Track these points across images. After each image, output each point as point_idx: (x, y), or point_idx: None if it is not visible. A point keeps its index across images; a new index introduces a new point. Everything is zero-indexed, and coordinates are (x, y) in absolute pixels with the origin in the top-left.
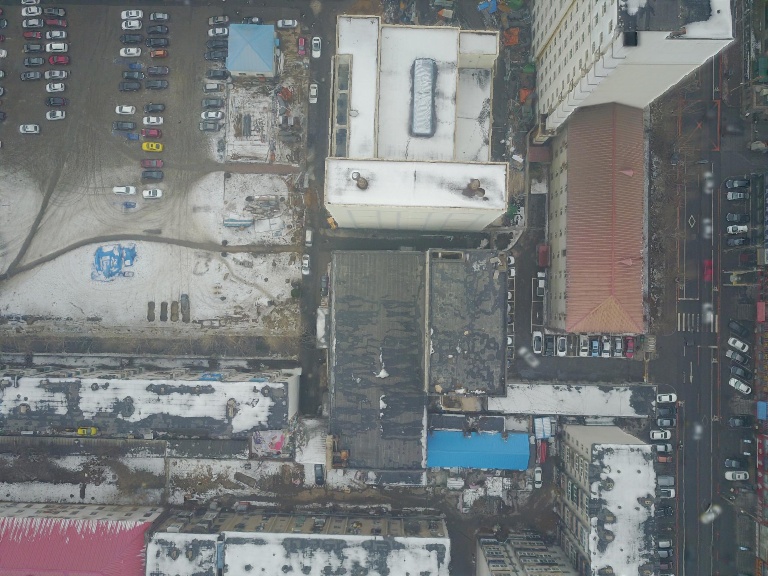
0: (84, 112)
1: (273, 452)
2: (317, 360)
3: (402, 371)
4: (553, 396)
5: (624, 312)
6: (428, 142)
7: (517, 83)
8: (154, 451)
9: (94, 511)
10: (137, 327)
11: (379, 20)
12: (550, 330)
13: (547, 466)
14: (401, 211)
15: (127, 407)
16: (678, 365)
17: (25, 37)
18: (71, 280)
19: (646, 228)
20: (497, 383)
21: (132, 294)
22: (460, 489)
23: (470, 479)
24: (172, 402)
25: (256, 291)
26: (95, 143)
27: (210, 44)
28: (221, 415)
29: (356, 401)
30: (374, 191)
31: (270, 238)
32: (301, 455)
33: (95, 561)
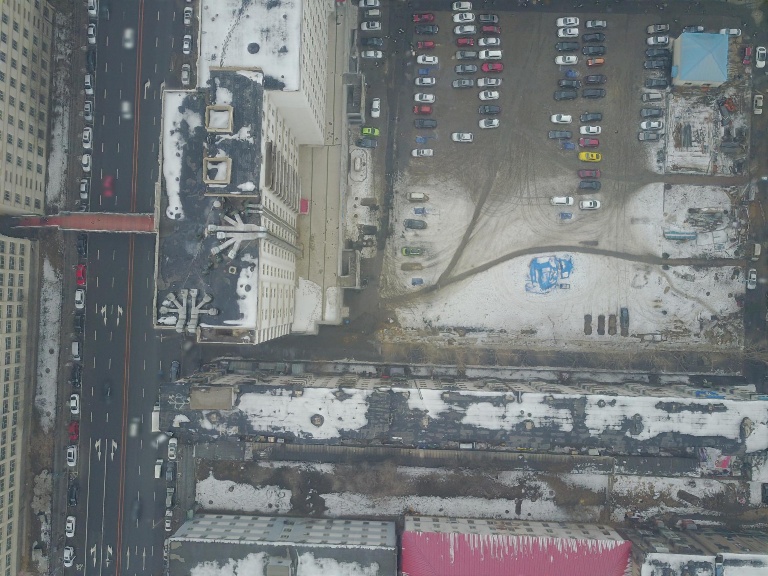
0: (517, 121)
1: (719, 470)
2: (762, 377)
3: None
4: None
5: None
6: None
7: None
8: (601, 468)
9: (546, 528)
10: (574, 340)
11: None
12: None
13: None
14: None
15: (639, 425)
16: None
17: (458, 44)
18: (504, 292)
19: None
20: None
21: (568, 307)
22: None
23: None
24: (683, 420)
25: (698, 305)
26: (528, 152)
27: (651, 53)
28: (734, 434)
29: None
30: None
31: (712, 251)
32: (758, 474)
33: None
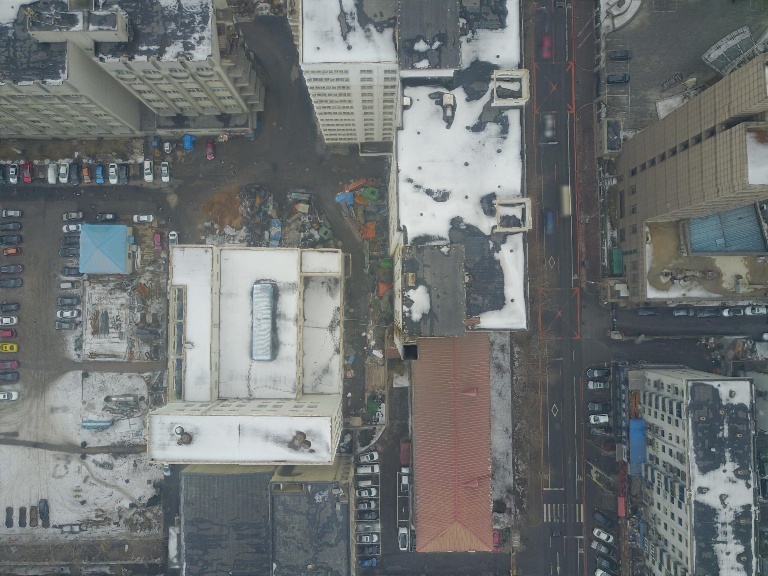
0: None
1: None
2: None
3: None
4: None
5: (471, 534)
6: (271, 365)
7: (376, 276)
8: None
9: None
10: None
11: (213, 250)
12: None
13: None
14: None
15: None
16: (545, 556)
17: None
18: None
19: (509, 419)
20: None
21: None
22: None
23: None
24: None
25: (117, 493)
26: None
27: (64, 241)
28: None
29: None
30: (198, 446)
31: (130, 438)
32: None
33: None
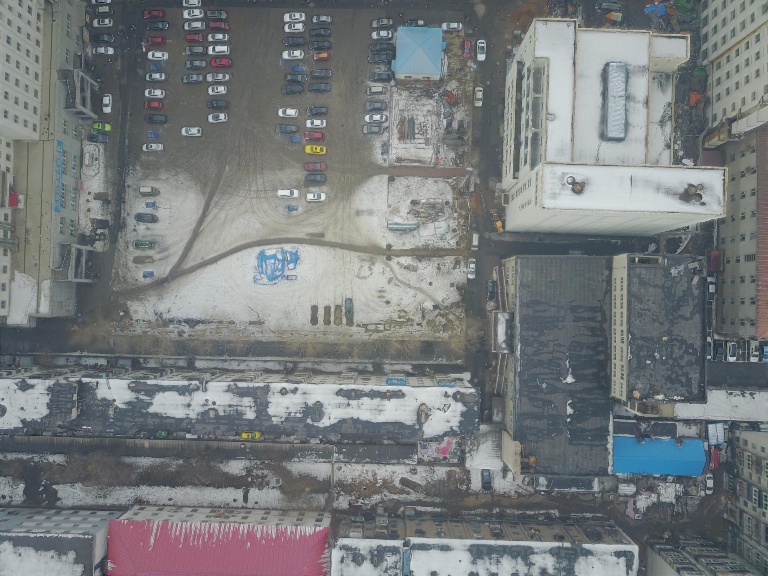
0: (246, 115)
1: (439, 457)
2: (483, 365)
3: (588, 376)
4: (727, 402)
5: None
6: (619, 146)
7: (686, 87)
8: (321, 456)
9: (263, 516)
10: (300, 331)
11: (576, 23)
12: (720, 335)
13: (718, 472)
14: (610, 216)
15: (318, 412)
16: None
17: (187, 39)
18: (233, 283)
19: None
20: (696, 389)
21: (295, 298)
22: (632, 495)
23: (639, 485)
24: (362, 407)
25: (421, 295)
26: (257, 146)
27: (374, 47)
28: (412, 420)
29: (542, 406)
30: (589, 196)
31: (434, 242)
32: (471, 460)
33: (279, 567)
